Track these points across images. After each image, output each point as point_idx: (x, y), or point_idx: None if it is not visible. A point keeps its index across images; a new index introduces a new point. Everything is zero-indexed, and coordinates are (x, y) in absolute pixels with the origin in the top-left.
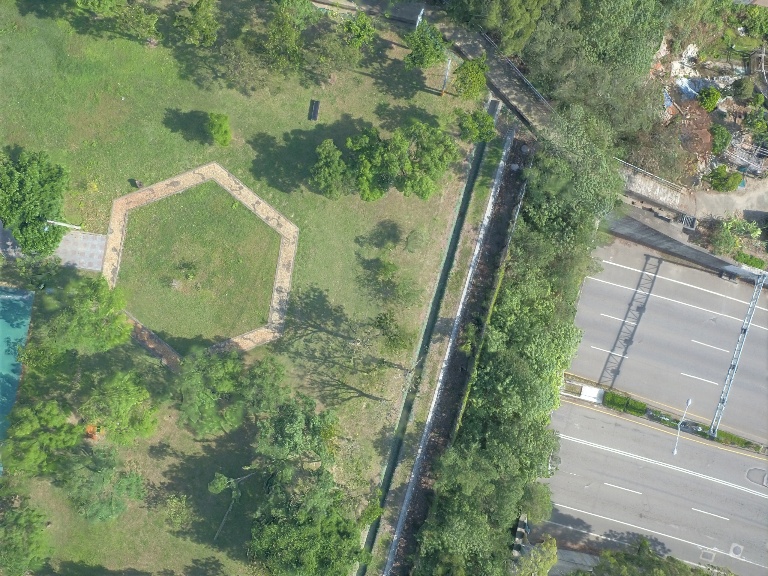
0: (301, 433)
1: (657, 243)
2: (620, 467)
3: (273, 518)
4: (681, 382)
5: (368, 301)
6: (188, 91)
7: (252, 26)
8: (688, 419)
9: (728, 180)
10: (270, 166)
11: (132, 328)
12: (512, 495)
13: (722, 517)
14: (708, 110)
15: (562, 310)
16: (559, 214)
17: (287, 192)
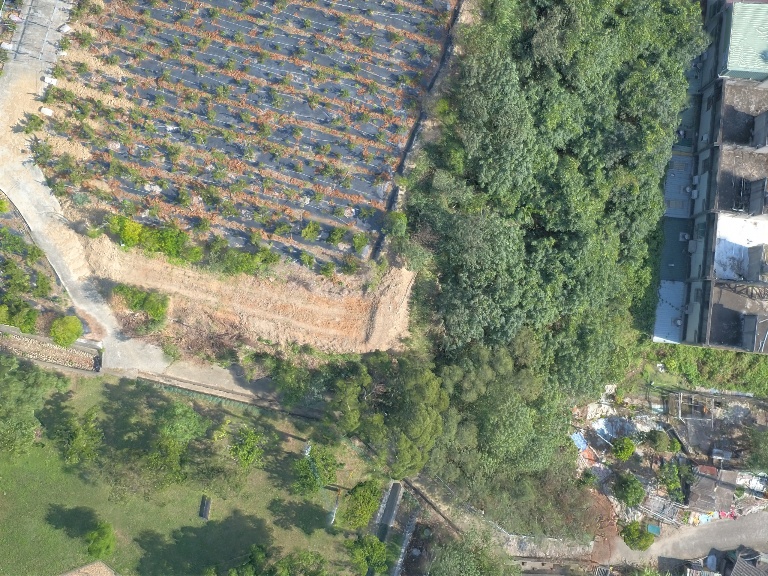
0: None
1: None
2: None
3: None
4: None
5: None
6: (74, 486)
7: (142, 417)
8: None
9: (640, 543)
10: (159, 565)
11: None
12: None
13: None
14: (623, 460)
15: None
16: None
17: None
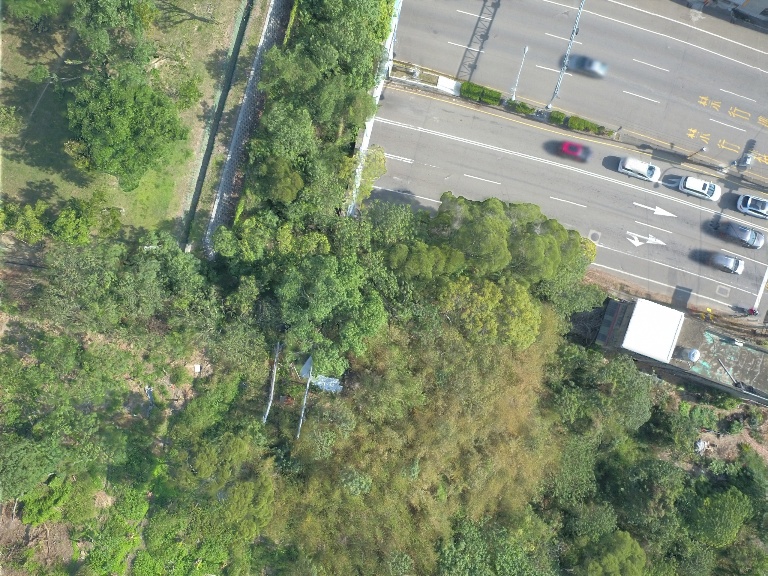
0: (116, 10)
1: None
2: (479, 158)
3: (87, 88)
4: (536, 74)
5: None
6: None
7: None
8: (544, 109)
9: None
10: None
11: None
12: (332, 85)
13: (579, 205)
14: None
15: None
16: None
17: None
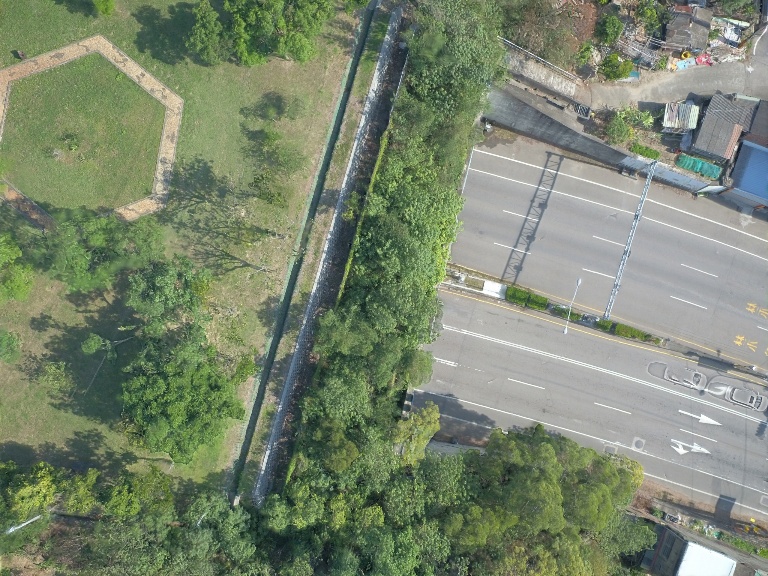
0: (173, 287)
1: (557, 138)
2: (523, 362)
3: (143, 371)
4: (583, 277)
5: (252, 172)
6: None
7: None
8: (590, 314)
9: (619, 67)
10: (155, 38)
11: (14, 199)
12: (389, 354)
13: (624, 411)
14: (601, 2)
15: (444, 179)
16: (441, 84)
17: (172, 64)
